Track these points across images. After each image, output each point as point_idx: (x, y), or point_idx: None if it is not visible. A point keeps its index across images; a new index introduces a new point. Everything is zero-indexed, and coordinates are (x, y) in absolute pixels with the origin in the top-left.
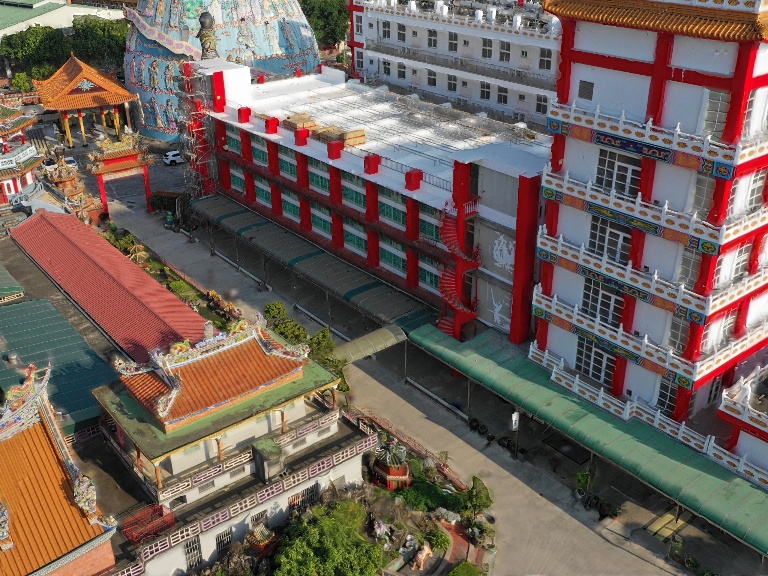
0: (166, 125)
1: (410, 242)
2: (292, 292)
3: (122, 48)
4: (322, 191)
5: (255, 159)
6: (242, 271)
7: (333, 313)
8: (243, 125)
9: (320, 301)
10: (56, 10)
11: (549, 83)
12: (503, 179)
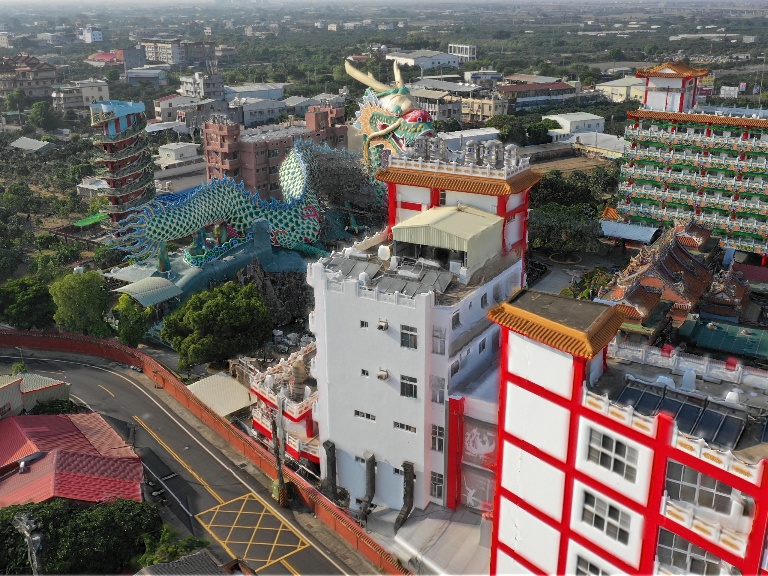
0: None
1: None
2: None
3: None
4: None
5: None
6: None
7: None
8: None
9: None
10: None
11: None
12: None
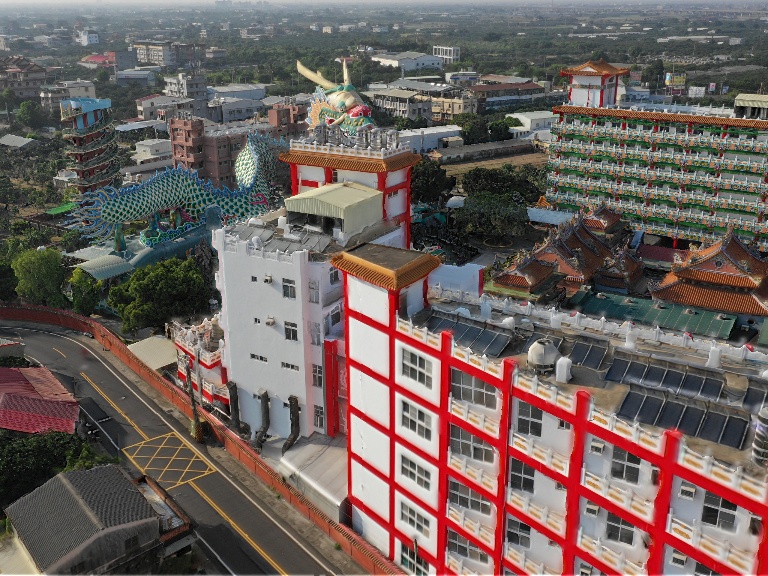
0: None
1: None
2: None
3: None
4: None
5: None
6: None
7: None
8: None
9: None
10: None
11: None
12: None
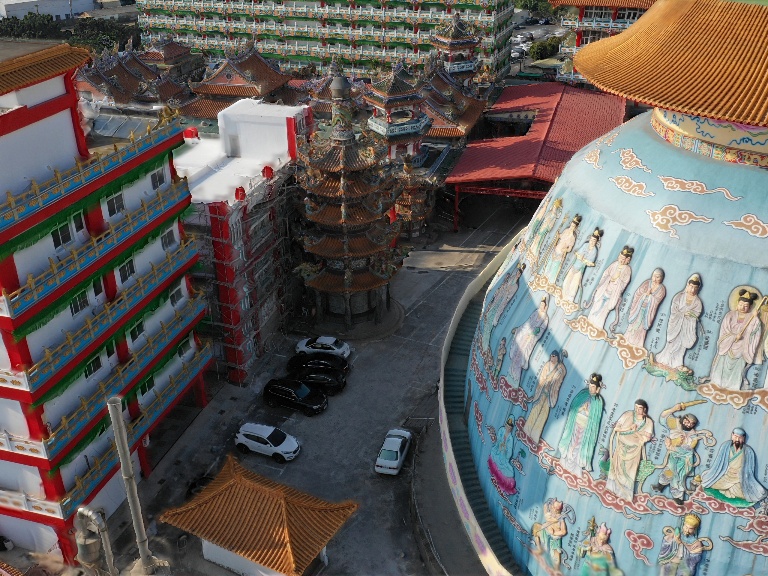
0: None
1: None
2: None
3: None
4: None
5: None
6: None
7: None
8: None
9: None
10: None
11: None
12: None
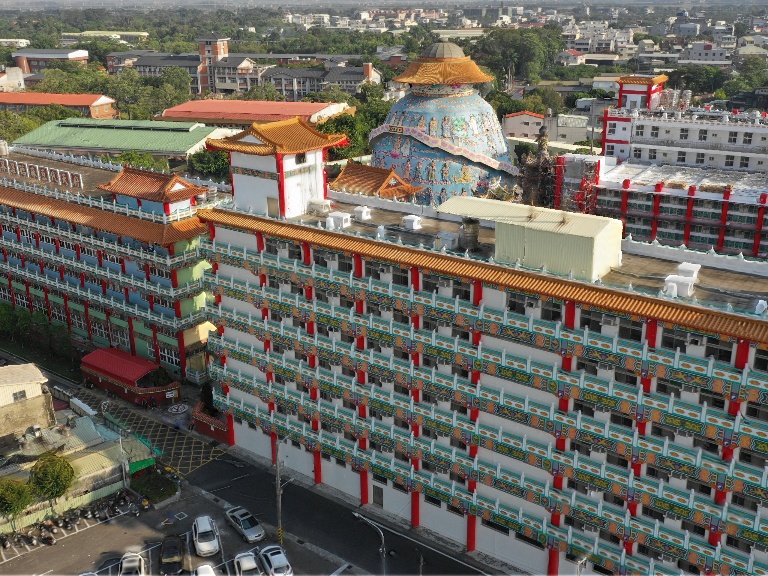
0: None
1: None
2: None
3: None
4: None
5: None
6: None
7: None
8: (631, 189)
9: None
10: (213, 132)
11: None
12: None
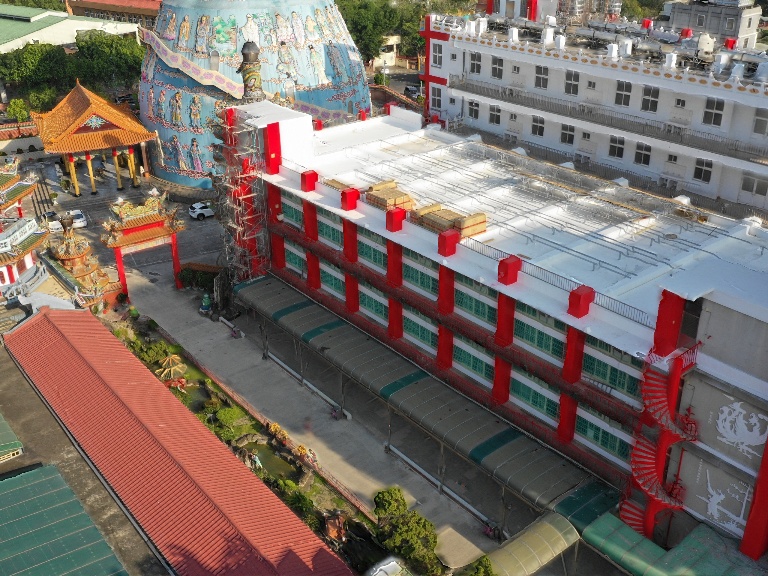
0: (190, 168)
1: (569, 385)
2: (379, 421)
3: (132, 67)
4: (422, 291)
5: (321, 236)
6: (307, 386)
7: (441, 459)
8: (308, 195)
9: (419, 438)
10: (57, 24)
11: (726, 146)
12: (750, 325)
